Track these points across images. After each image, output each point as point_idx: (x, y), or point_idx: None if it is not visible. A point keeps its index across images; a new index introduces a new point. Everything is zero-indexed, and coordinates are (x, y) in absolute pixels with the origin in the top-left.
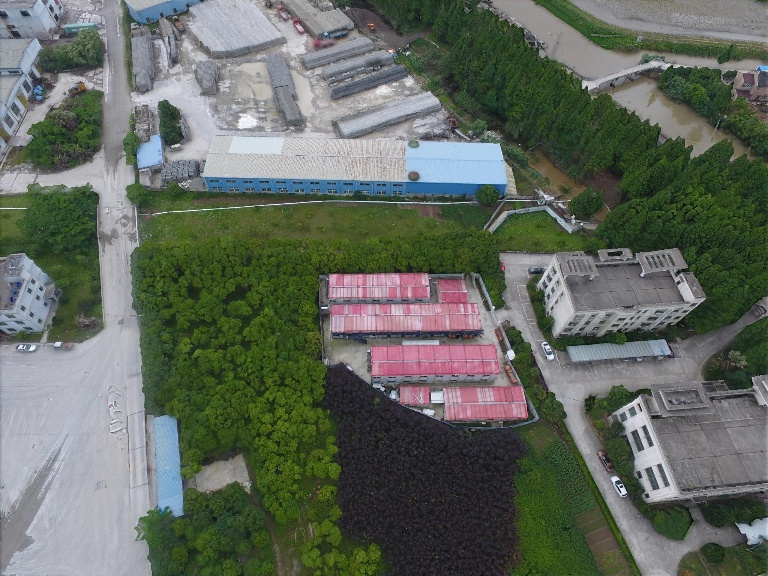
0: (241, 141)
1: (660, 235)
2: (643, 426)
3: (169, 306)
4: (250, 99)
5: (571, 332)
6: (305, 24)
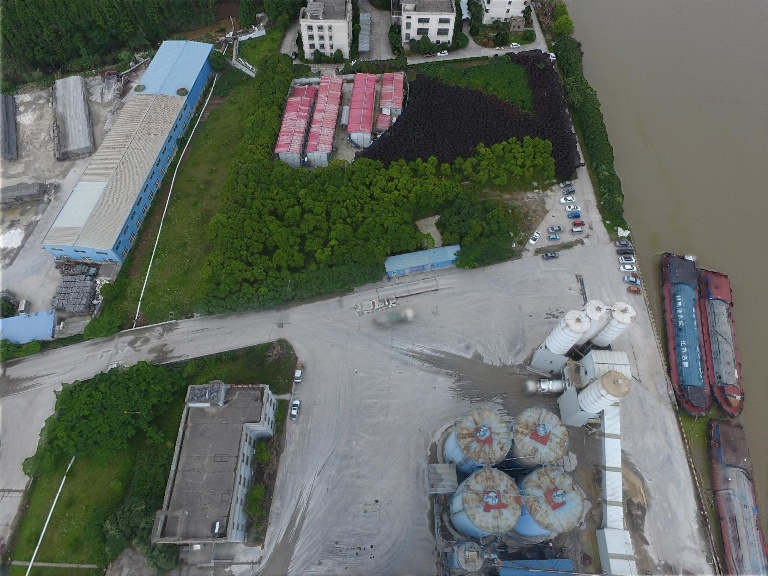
0: (66, 218)
1: None
2: (418, 21)
3: (278, 271)
4: None
5: None
6: None
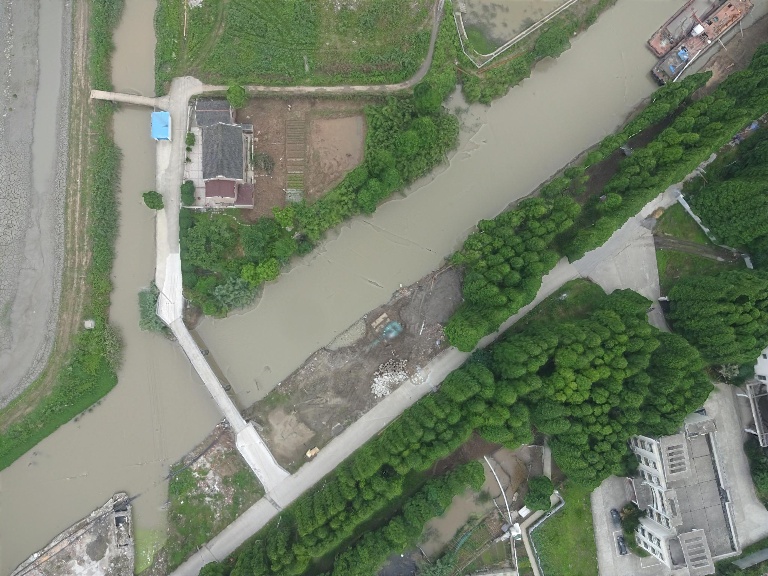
0: None
1: None
2: None
3: None
4: None
5: None
6: None
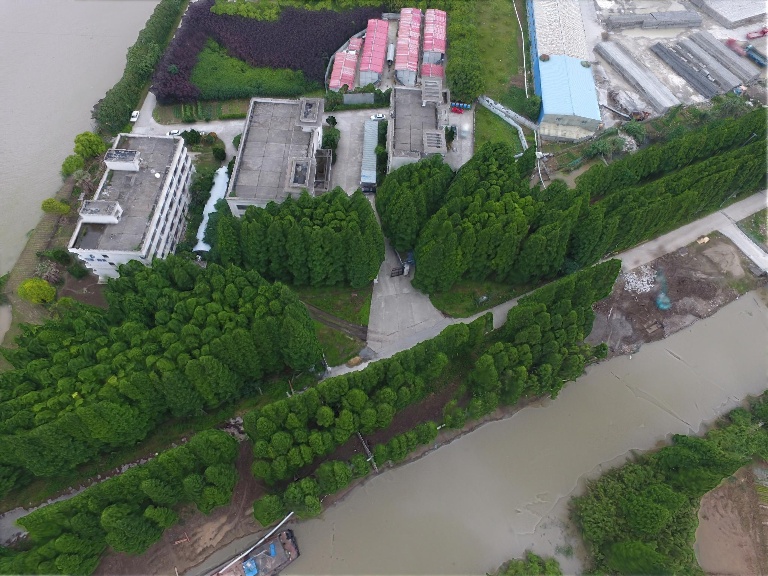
0: None
1: None
2: None
3: None
4: (634, 6)
5: None
6: None
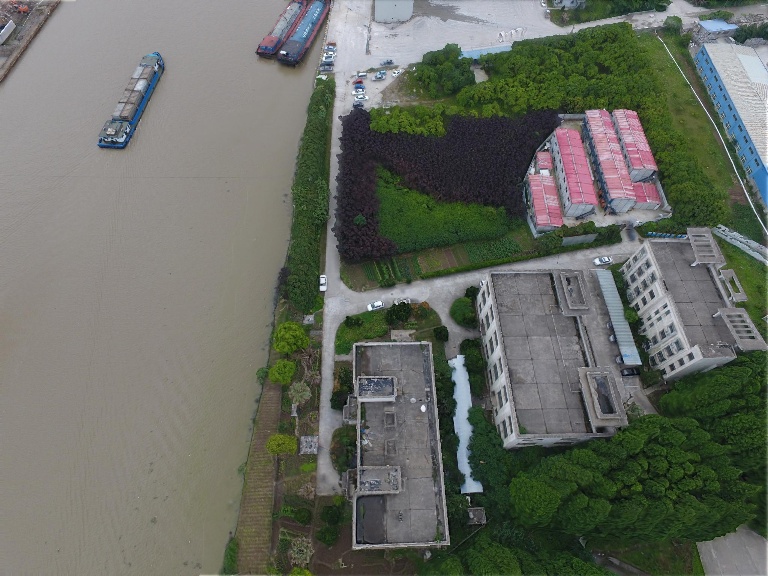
0: (755, 61)
1: None
2: None
3: None
4: None
5: (627, 276)
6: None
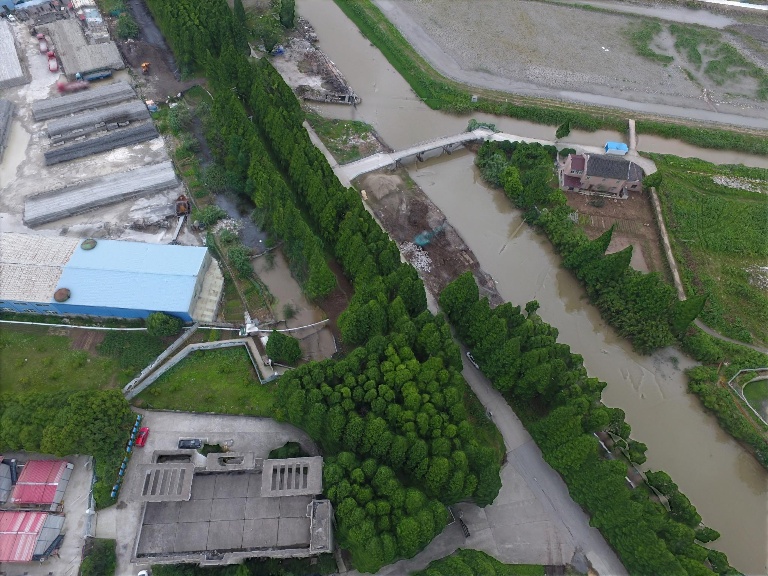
0: None
1: (324, 423)
2: None
3: None
4: None
5: None
6: (61, 60)
